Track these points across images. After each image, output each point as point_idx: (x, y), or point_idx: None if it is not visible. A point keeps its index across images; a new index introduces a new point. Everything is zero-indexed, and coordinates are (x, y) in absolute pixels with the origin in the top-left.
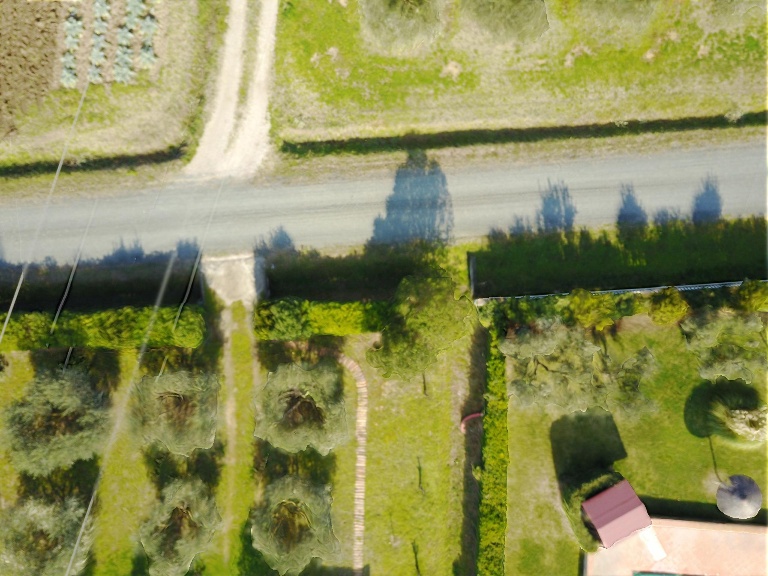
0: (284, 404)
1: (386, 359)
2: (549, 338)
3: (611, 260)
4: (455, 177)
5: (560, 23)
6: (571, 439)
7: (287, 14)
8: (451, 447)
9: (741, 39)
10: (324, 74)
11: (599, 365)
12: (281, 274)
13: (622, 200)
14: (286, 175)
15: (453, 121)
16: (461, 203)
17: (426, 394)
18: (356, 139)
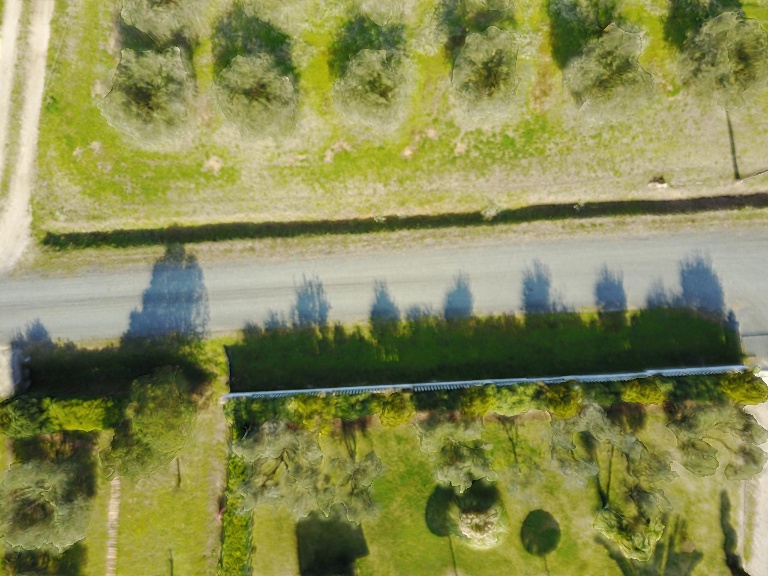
0: (18, 502)
1: (108, 463)
2: (271, 443)
3: (364, 355)
4: (212, 271)
5: (320, 119)
6: (317, 535)
7: (50, 108)
8: (209, 538)
9: (497, 138)
10: (86, 167)
11: (348, 461)
12: (41, 365)
13: (376, 296)
14: (45, 267)
15: (215, 214)
16: (217, 297)
17: (179, 487)
18: (121, 230)
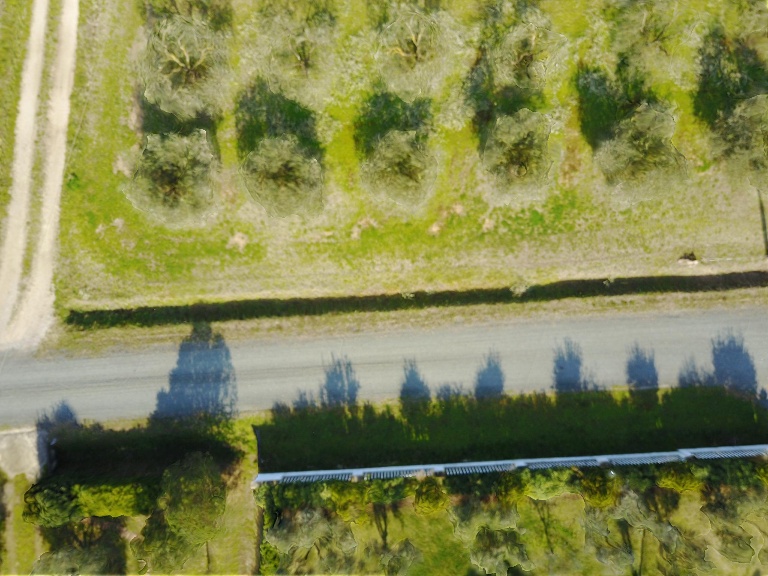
0: None
1: (141, 557)
2: (305, 535)
3: (394, 435)
4: (239, 351)
5: (347, 195)
6: None
7: (71, 185)
8: None
9: (526, 213)
10: (109, 245)
11: (378, 542)
12: (66, 446)
13: (405, 375)
14: (69, 348)
15: (240, 292)
16: (245, 377)
17: (208, 568)
18: (145, 308)
